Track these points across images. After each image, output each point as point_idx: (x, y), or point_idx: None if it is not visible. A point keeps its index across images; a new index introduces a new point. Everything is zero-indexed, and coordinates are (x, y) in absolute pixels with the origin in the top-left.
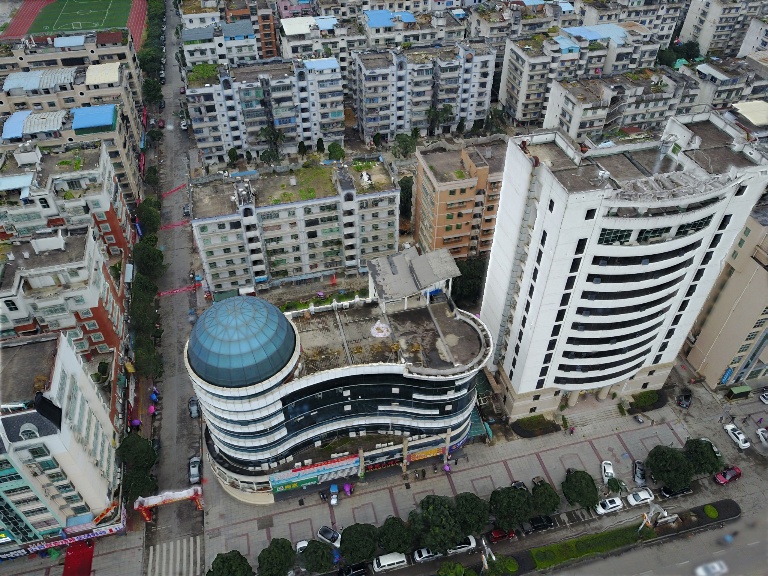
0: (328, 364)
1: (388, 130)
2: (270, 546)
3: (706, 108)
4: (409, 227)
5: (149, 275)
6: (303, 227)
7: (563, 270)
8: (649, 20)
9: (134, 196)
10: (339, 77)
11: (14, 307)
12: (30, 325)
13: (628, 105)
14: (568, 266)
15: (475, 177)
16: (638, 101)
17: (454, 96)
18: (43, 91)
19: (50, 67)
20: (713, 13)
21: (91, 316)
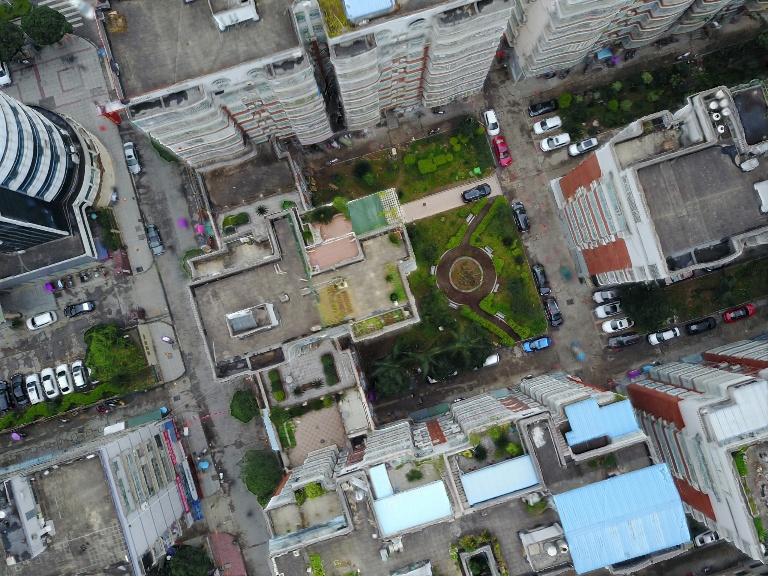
0: None
1: None
2: (6, 47)
3: None
4: None
5: None
6: None
7: None
8: None
9: None
10: None
11: None
12: None
13: None
14: None
15: None
16: None
17: None
18: None
19: None
20: None
21: None
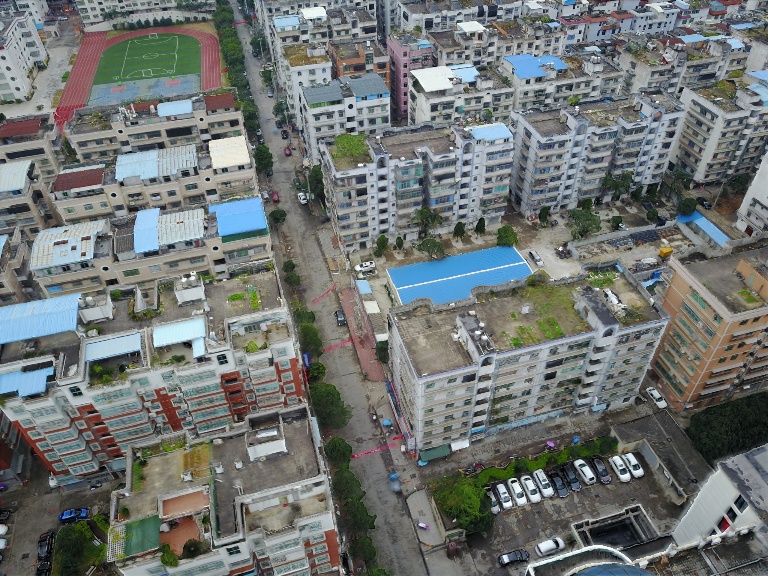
0: None
1: (555, 202)
2: None
3: None
4: None
5: (330, 425)
6: (542, 368)
7: None
8: None
9: None
10: (511, 147)
11: (236, 550)
12: (250, 565)
13: None
14: None
15: None
16: None
17: (634, 160)
18: (163, 179)
19: (153, 139)
20: None
21: (323, 540)
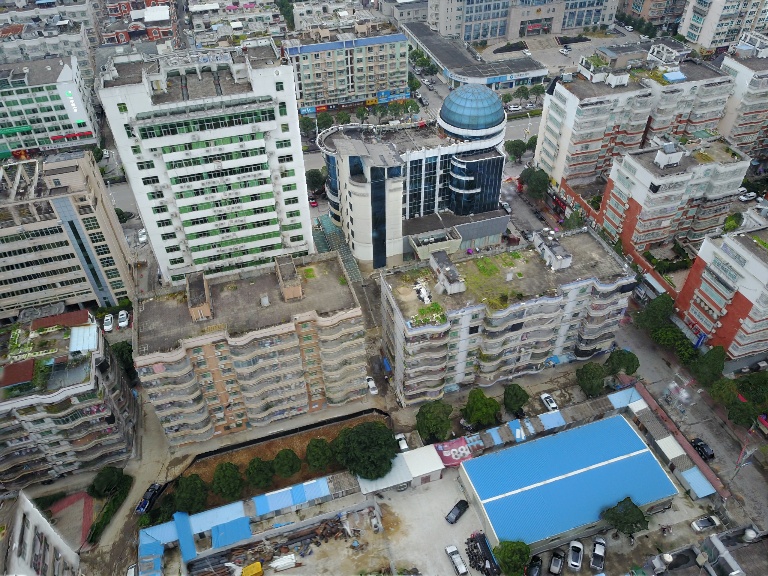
0: (421, 131)
1: None
2: None
3: None
4: None
5: None
6: None
7: None
8: None
9: None
10: None
11: None
12: None
13: None
14: None
15: None
16: None
17: None
18: None
19: None
20: None
21: None
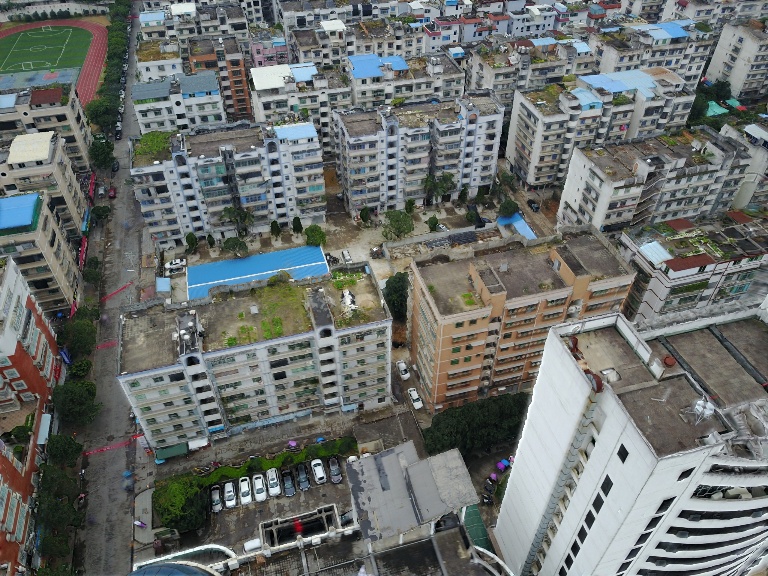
0: None
1: (378, 202)
2: None
3: (757, 178)
4: (404, 336)
5: (75, 422)
6: (267, 368)
7: (635, 529)
8: (675, 60)
9: (67, 301)
10: (317, 147)
11: None
12: None
13: (667, 181)
14: (643, 524)
15: (489, 306)
16: (679, 175)
17: (455, 162)
18: None
19: None
20: (747, 50)
21: None
